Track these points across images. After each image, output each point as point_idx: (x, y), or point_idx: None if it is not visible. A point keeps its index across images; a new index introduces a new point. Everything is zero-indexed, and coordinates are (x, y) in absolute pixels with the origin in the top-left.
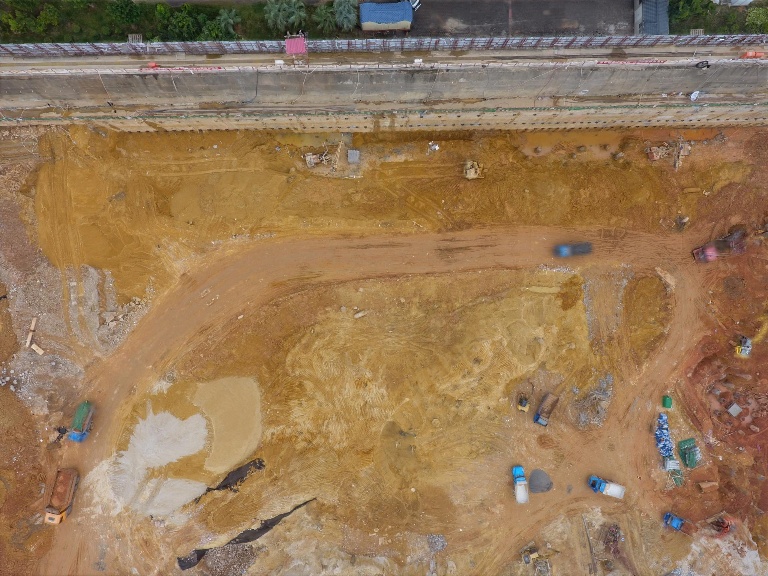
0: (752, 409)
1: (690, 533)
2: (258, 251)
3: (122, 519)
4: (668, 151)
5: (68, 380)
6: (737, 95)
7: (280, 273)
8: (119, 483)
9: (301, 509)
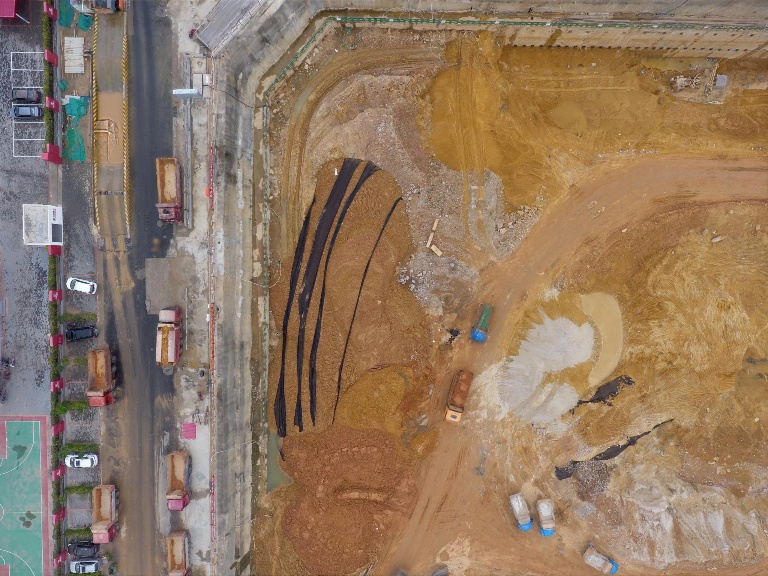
0: None
1: None
2: (643, 166)
3: (505, 425)
4: None
5: (464, 282)
6: None
7: (661, 190)
8: (506, 388)
9: (653, 431)
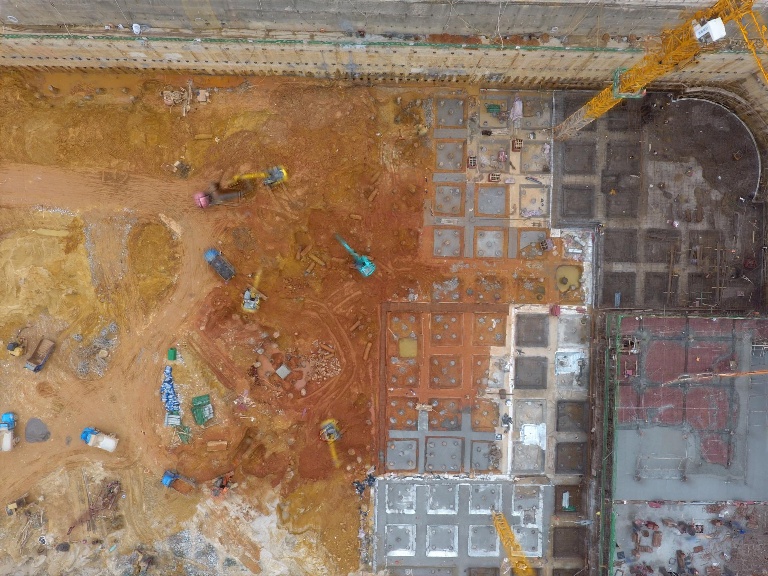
0: (306, 372)
1: (185, 492)
2: None
3: None
4: (184, 96)
5: None
6: (184, 31)
7: None
8: None
9: None
